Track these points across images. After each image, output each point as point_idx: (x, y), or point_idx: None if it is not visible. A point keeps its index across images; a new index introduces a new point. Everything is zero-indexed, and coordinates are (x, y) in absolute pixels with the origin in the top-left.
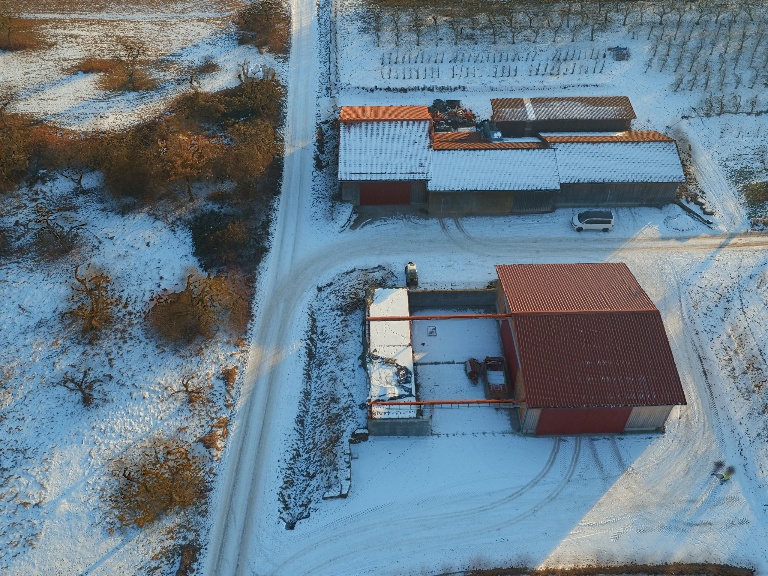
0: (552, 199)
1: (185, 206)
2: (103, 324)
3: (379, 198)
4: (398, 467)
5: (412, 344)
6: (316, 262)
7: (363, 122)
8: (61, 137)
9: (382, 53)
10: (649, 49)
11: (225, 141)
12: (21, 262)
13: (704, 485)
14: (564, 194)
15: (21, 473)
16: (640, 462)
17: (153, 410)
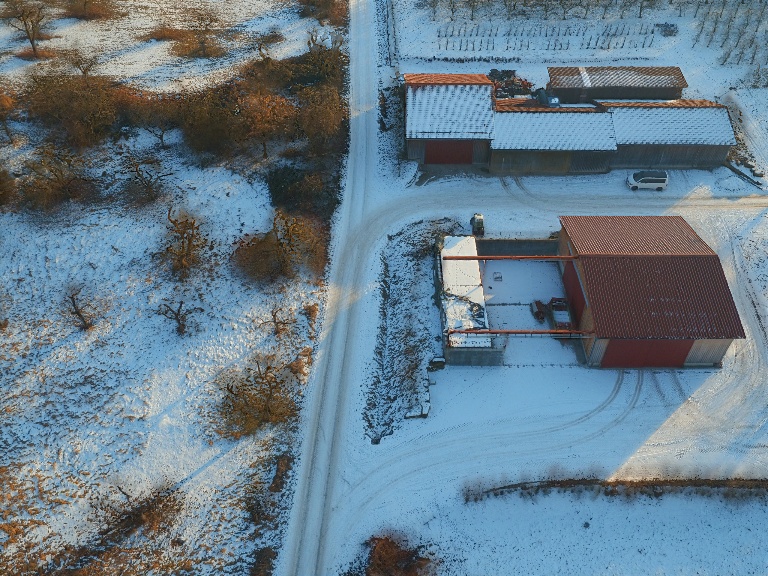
0: (608, 160)
1: (260, 162)
2: (191, 264)
3: (442, 157)
4: (473, 392)
5: None
6: (385, 214)
7: (428, 85)
8: (140, 97)
9: (438, 27)
10: (696, 25)
11: (294, 104)
12: (111, 208)
13: (761, 414)
14: (619, 156)
15: (125, 391)
16: (700, 393)
17: (242, 340)
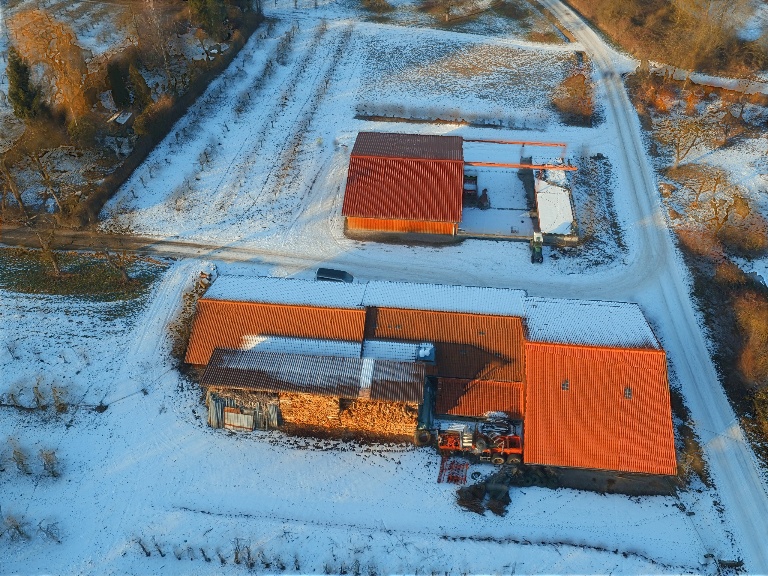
0: None
1: None
2: None
3: None
4: None
5: (532, 222)
6: (635, 284)
7: (628, 348)
8: None
9: None
10: None
11: None
12: None
13: None
14: None
15: None
16: None
17: None
